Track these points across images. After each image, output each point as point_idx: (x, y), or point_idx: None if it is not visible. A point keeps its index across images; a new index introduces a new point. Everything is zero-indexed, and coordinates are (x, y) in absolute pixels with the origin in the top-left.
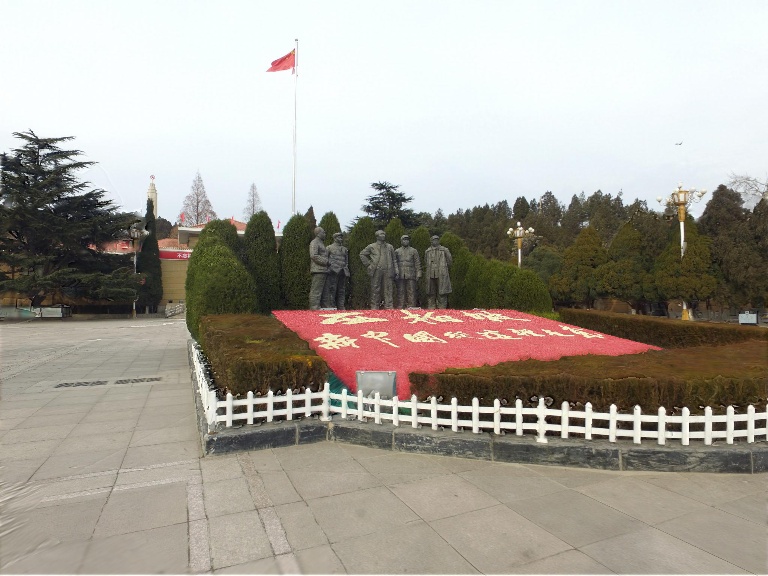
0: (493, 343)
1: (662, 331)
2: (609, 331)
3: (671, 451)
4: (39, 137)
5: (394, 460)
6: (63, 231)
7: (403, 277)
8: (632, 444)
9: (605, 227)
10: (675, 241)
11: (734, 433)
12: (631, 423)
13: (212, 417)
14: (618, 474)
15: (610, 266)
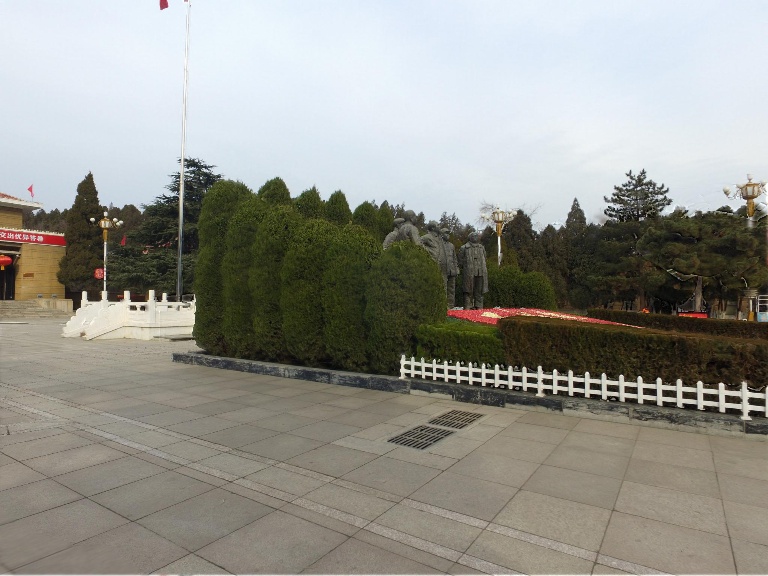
0: None
1: (706, 326)
2: None
3: None
4: None
5: None
6: None
7: None
8: None
9: None
10: (493, 252)
11: None
12: None
13: None
14: None
15: None
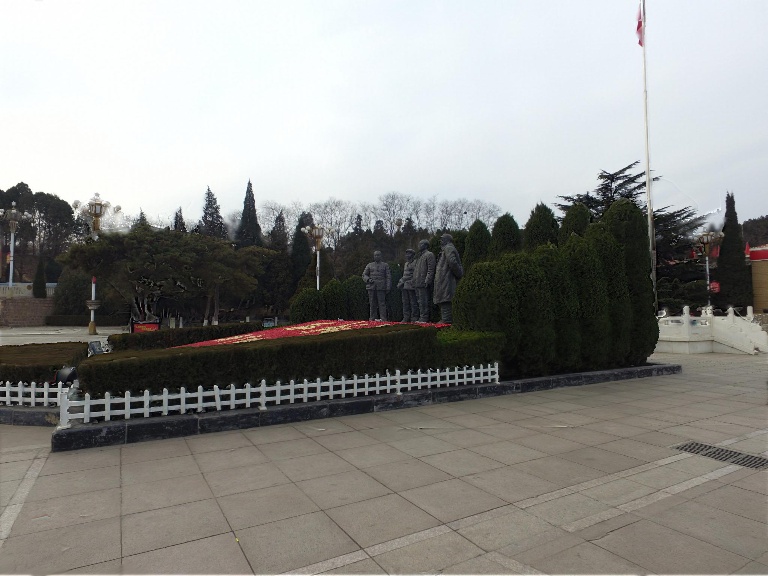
0: None
1: None
2: None
3: None
4: (611, 173)
5: None
6: None
7: None
8: None
9: None
10: None
11: None
12: None
13: None
14: None
15: None
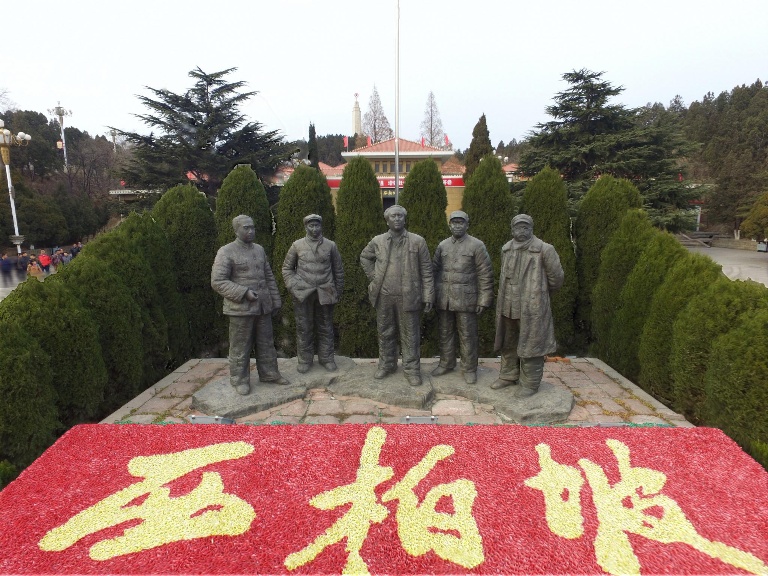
0: None
1: None
2: None
3: None
4: (207, 73)
5: None
6: (227, 168)
7: (445, 306)
8: None
9: None
10: None
11: None
12: None
13: None
14: None
15: None
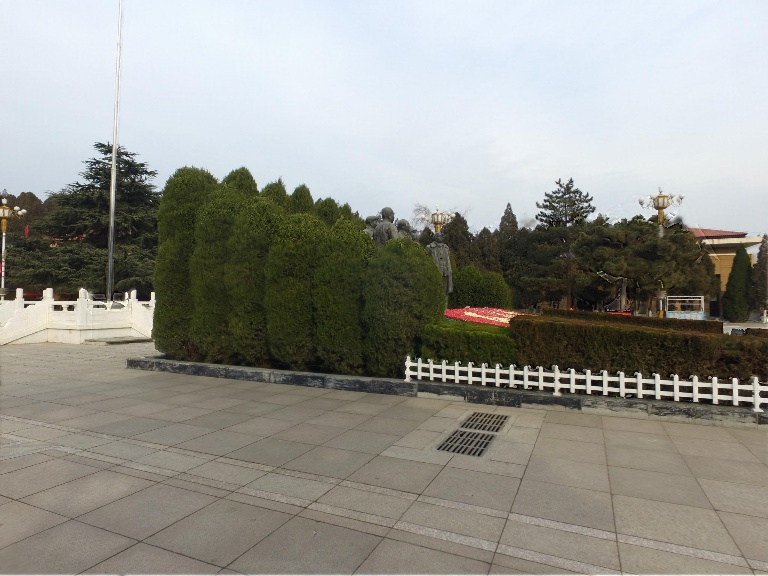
0: None
1: (650, 324)
2: None
3: None
4: None
5: None
6: None
7: None
8: None
9: None
10: None
11: None
12: None
13: None
14: None
15: None
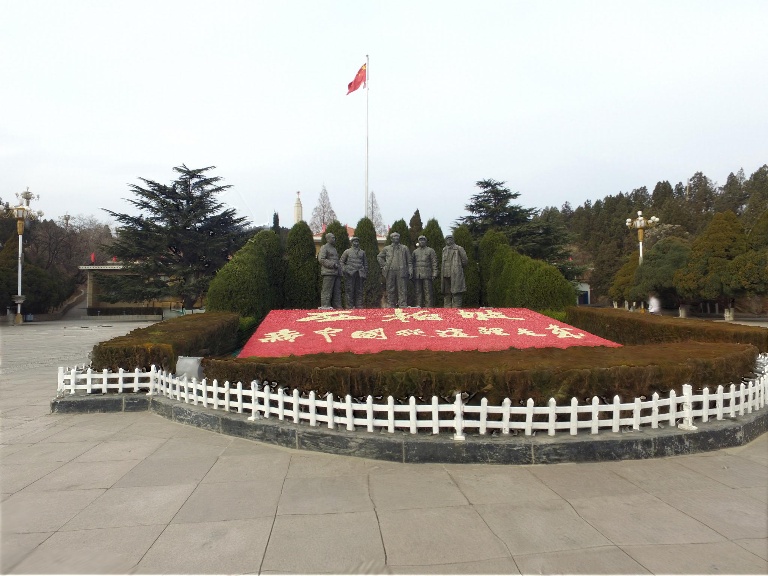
0: (434, 341)
1: (643, 331)
2: (604, 331)
3: (336, 435)
4: (190, 169)
5: (156, 427)
6: (206, 245)
7: (418, 277)
8: (313, 427)
9: (748, 210)
10: None
11: (396, 423)
12: (308, 407)
13: (60, 386)
14: (287, 451)
15: (747, 257)
